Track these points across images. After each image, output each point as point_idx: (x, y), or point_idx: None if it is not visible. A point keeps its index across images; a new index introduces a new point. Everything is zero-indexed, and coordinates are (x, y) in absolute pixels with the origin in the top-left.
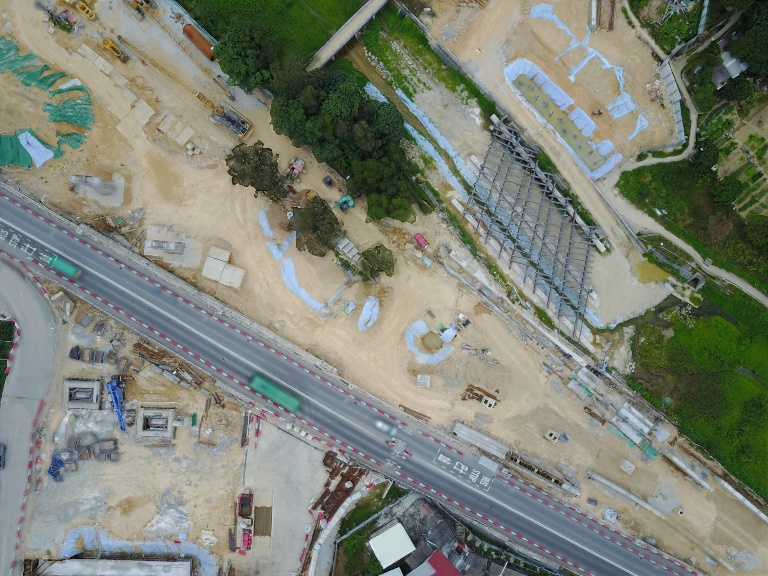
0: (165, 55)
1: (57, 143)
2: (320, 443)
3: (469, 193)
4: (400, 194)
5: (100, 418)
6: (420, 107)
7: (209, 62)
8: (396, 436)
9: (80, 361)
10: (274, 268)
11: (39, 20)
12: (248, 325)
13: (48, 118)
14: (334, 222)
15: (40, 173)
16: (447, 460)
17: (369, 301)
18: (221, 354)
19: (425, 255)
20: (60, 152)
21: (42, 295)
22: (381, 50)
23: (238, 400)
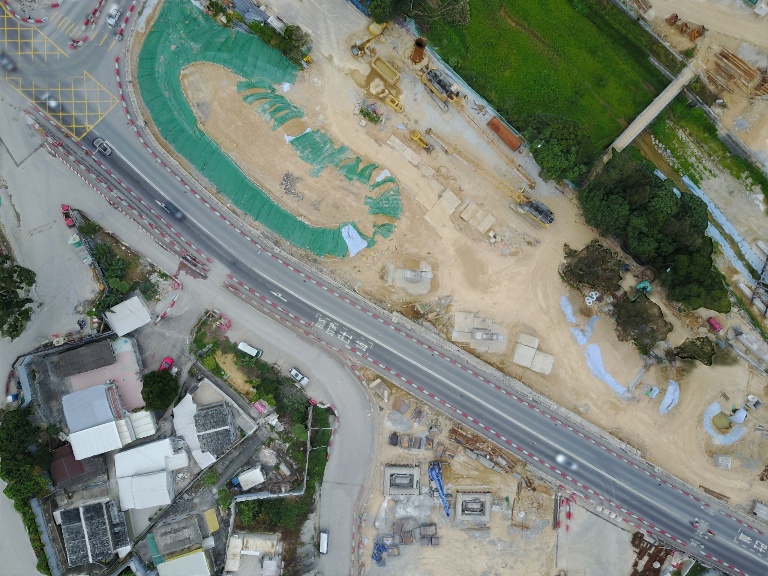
0: (467, 145)
1: (373, 234)
2: (627, 524)
3: (754, 276)
4: (714, 285)
5: (417, 503)
6: (707, 193)
7: (510, 152)
8: (698, 516)
9: (397, 447)
10: (578, 353)
11: (350, 113)
12: (556, 409)
13: (368, 211)
14: (661, 315)
15: (353, 262)
16: (747, 539)
17: (671, 385)
18: (531, 438)
19: (717, 338)
20: (373, 242)
21: (361, 383)
22: (669, 138)
23: (548, 483)
